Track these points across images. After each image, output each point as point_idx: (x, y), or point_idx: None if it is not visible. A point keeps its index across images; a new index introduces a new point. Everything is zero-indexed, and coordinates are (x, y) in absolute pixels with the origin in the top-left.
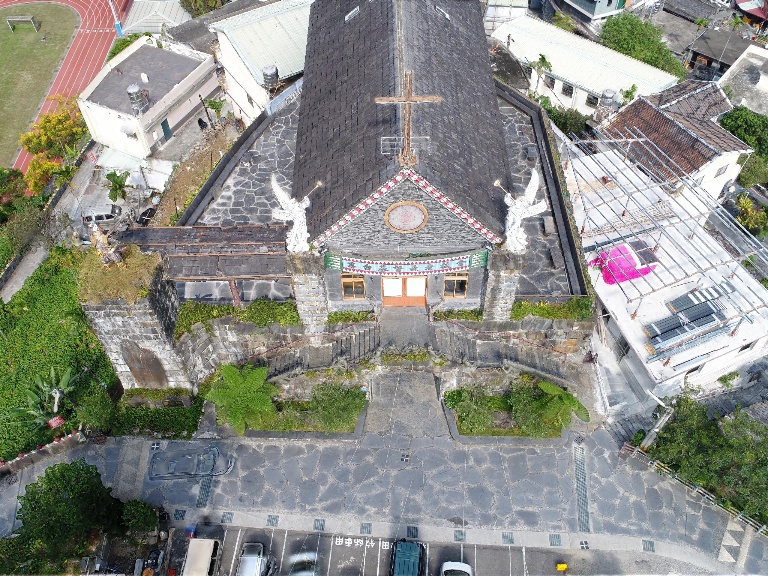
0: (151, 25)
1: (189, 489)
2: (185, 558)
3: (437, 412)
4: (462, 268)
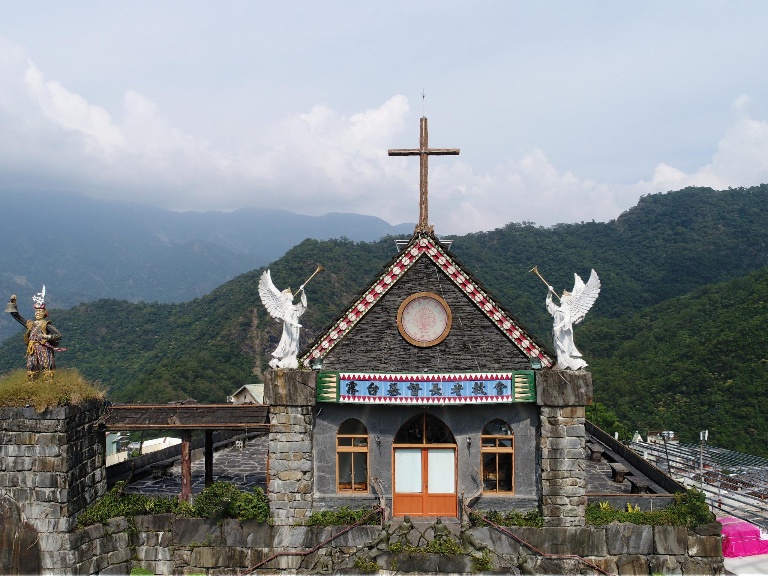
0: None
1: None
2: None
3: None
4: (502, 398)
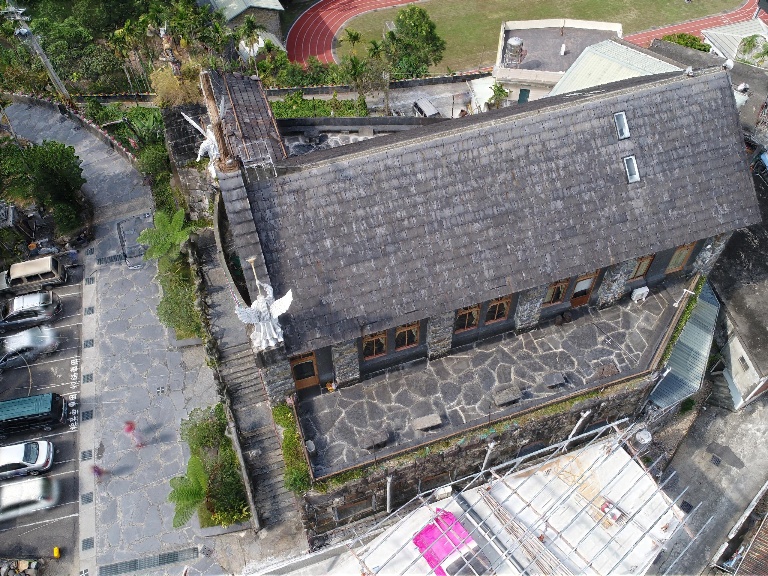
0: (729, 44)
1: (112, 249)
2: None
3: (215, 404)
4: None
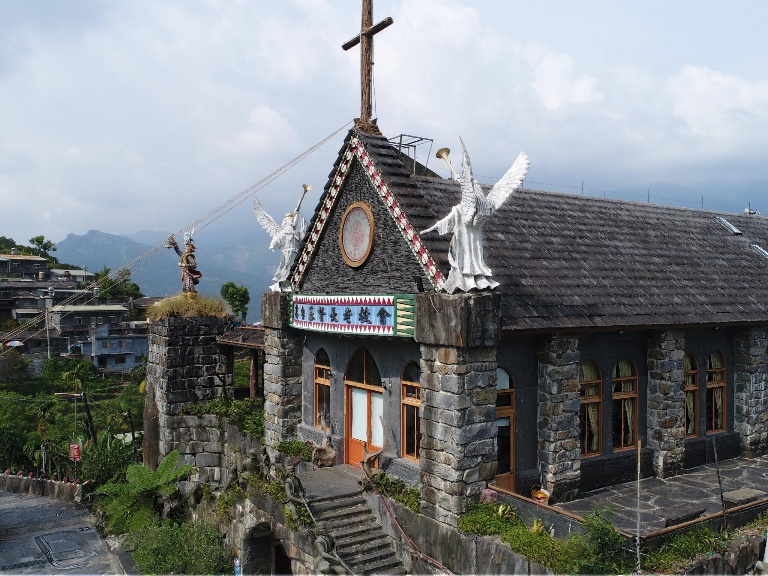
0: None
1: (26, 556)
2: None
3: None
4: (385, 330)
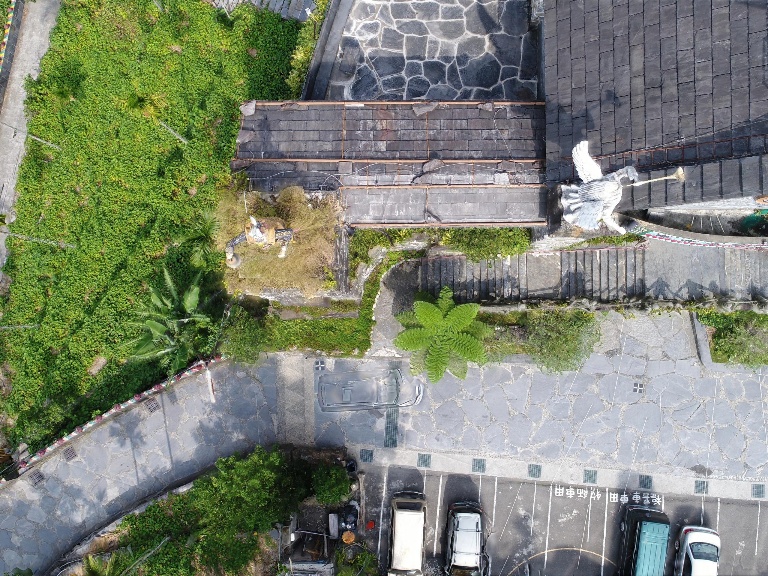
0: None
1: (372, 424)
2: (393, 533)
3: (682, 324)
4: None
